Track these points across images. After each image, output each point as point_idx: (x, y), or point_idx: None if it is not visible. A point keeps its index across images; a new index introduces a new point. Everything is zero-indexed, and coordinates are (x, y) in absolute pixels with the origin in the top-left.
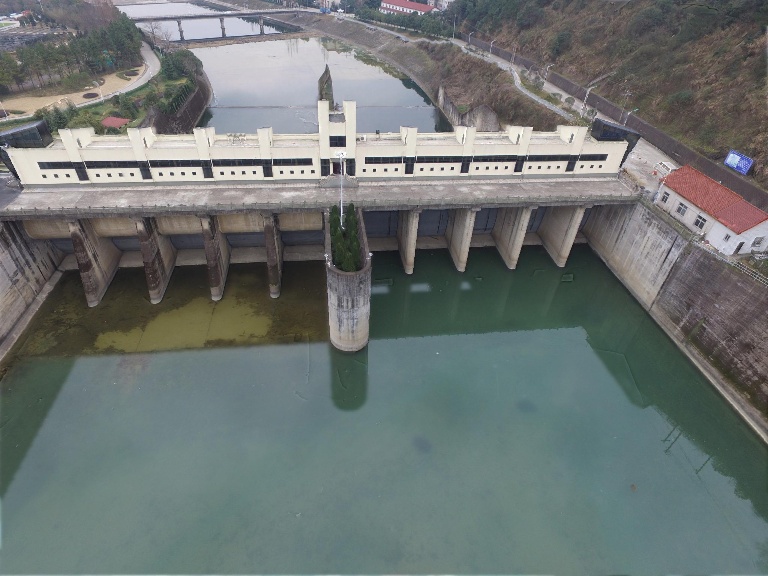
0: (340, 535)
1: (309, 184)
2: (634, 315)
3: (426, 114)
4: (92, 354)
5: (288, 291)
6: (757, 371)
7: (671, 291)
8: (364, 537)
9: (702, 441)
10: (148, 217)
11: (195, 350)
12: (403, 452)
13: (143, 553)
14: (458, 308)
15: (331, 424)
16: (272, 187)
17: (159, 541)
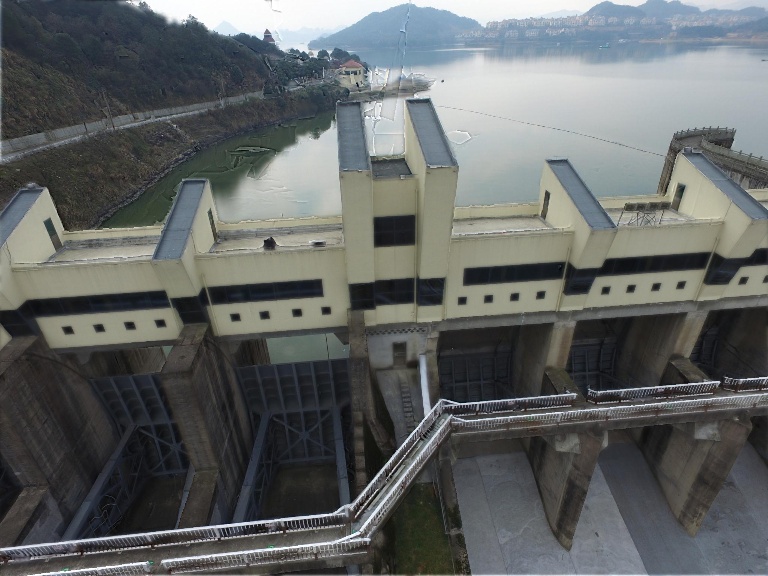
0: None
1: None
2: None
3: None
4: None
5: None
6: None
7: None
8: None
9: None
10: None
11: None
12: None
13: None
14: None
15: None
16: None
17: None
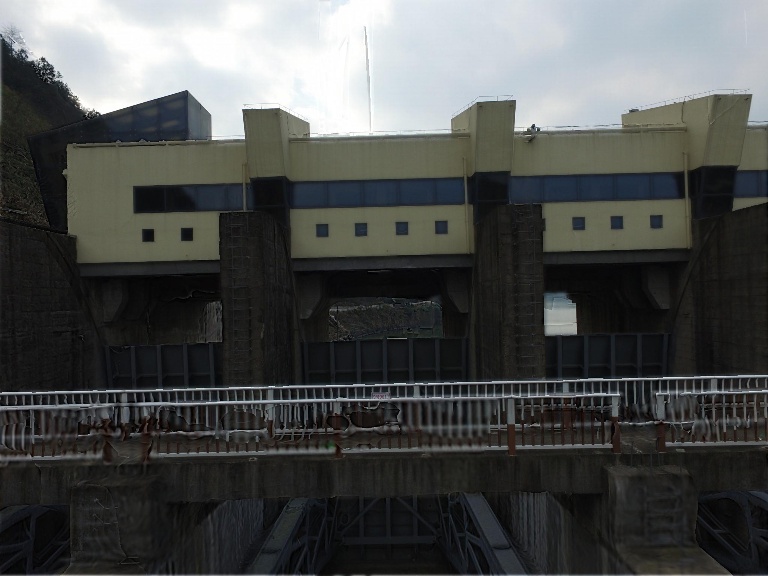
0: None
1: None
2: None
3: None
4: None
5: None
6: None
7: None
8: None
9: None
10: None
11: None
12: None
13: None
14: None
15: None
16: None
17: None
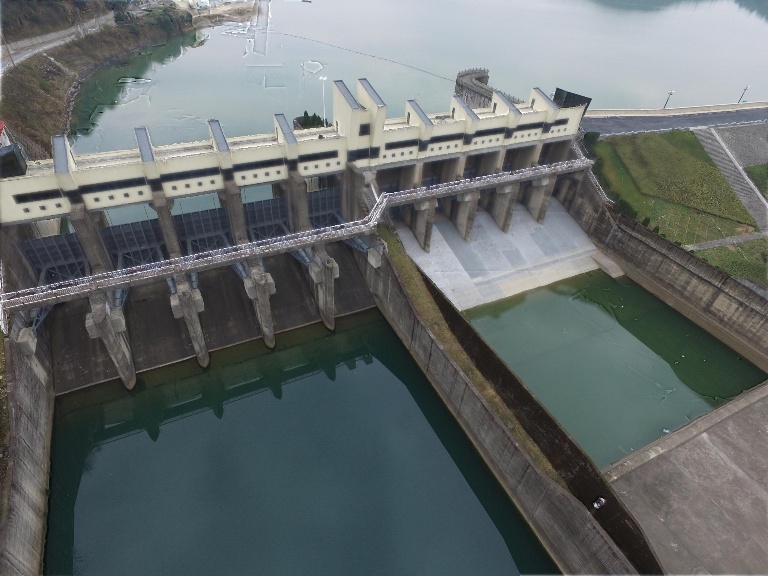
0: None
1: None
2: None
3: None
4: None
5: None
6: None
7: None
8: None
9: None
10: None
11: None
12: None
13: None
14: None
15: None
16: None
17: None
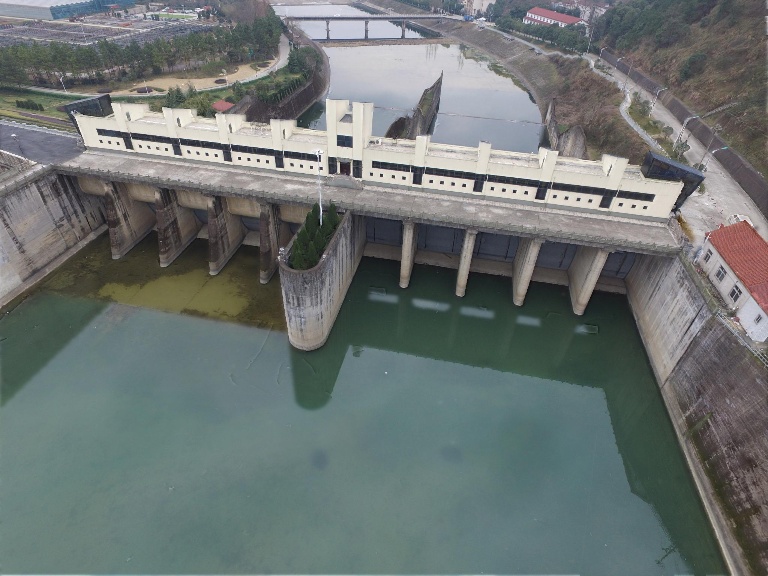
0: (195, 520)
1: (317, 180)
2: (648, 389)
3: (531, 130)
4: (93, 299)
5: (278, 280)
6: (751, 497)
7: (685, 370)
8: (215, 530)
9: (692, 564)
10: (165, 188)
11: (171, 315)
12: (296, 461)
13: (36, 477)
14: (457, 335)
15: (247, 414)
16: (281, 178)
17: (53, 471)
